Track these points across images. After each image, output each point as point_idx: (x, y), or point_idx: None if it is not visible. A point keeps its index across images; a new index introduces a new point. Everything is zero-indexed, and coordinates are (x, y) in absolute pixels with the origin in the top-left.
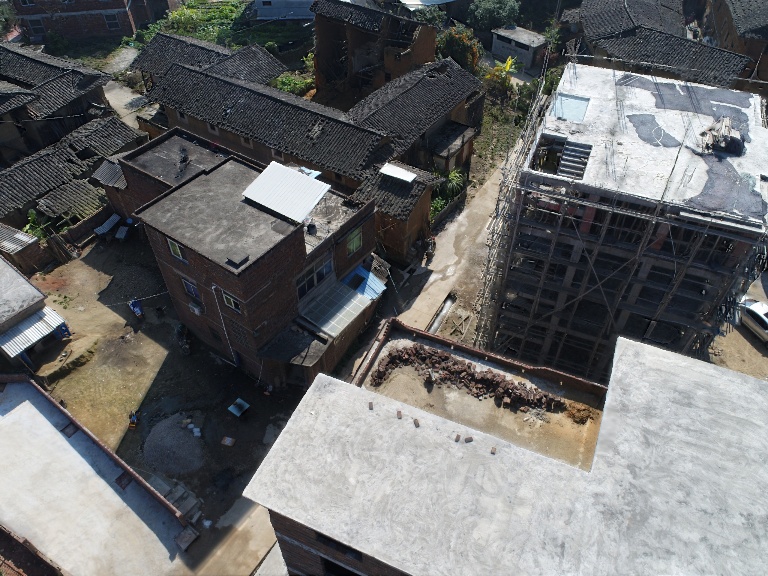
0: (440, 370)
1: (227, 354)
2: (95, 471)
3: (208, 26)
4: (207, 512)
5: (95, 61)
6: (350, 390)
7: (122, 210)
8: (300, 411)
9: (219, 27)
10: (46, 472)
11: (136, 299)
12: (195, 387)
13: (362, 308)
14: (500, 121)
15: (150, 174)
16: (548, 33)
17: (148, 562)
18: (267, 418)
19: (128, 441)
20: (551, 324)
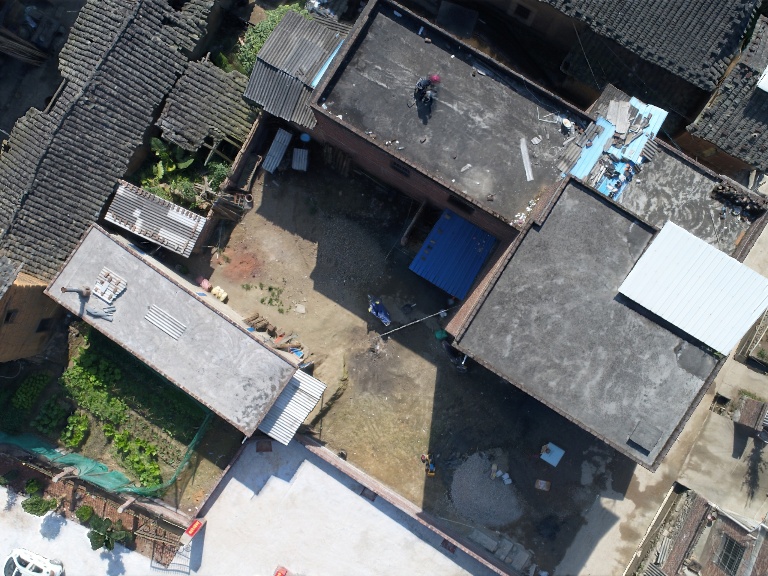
0: None
1: None
2: (416, 536)
3: None
4: (540, 563)
5: None
6: None
7: None
8: None
9: None
10: (367, 542)
11: (378, 303)
12: (485, 417)
13: None
14: None
15: (383, 148)
16: None
17: None
18: (580, 454)
19: (432, 490)
20: None
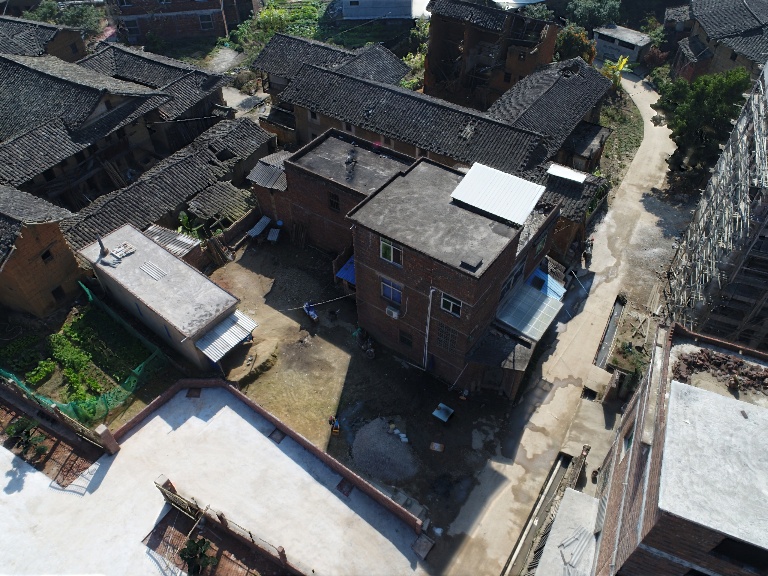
0: (739, 376)
1: (414, 358)
2: (314, 478)
3: (295, 26)
4: (435, 519)
5: (195, 62)
6: (714, 398)
7: (271, 212)
8: (674, 420)
9: (306, 27)
10: (265, 479)
11: (310, 302)
12: (388, 392)
13: (556, 311)
14: (617, 121)
15: (322, 176)
16: (652, 32)
17: (391, 571)
18: (470, 423)
19: (334, 447)
20: (763, 327)
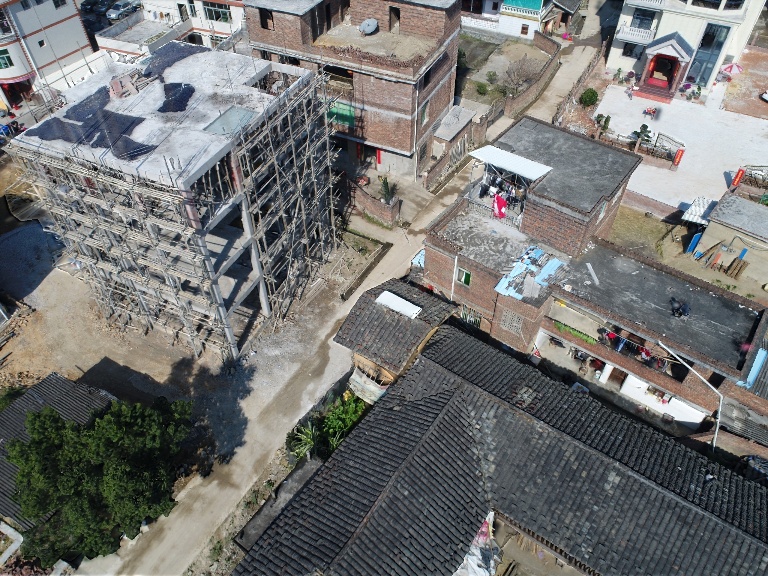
0: None
1: None
2: None
3: None
4: None
5: None
6: None
7: None
8: None
9: None
10: None
11: None
12: None
13: (433, 222)
14: None
15: (703, 281)
16: None
17: None
18: None
19: None
20: None
